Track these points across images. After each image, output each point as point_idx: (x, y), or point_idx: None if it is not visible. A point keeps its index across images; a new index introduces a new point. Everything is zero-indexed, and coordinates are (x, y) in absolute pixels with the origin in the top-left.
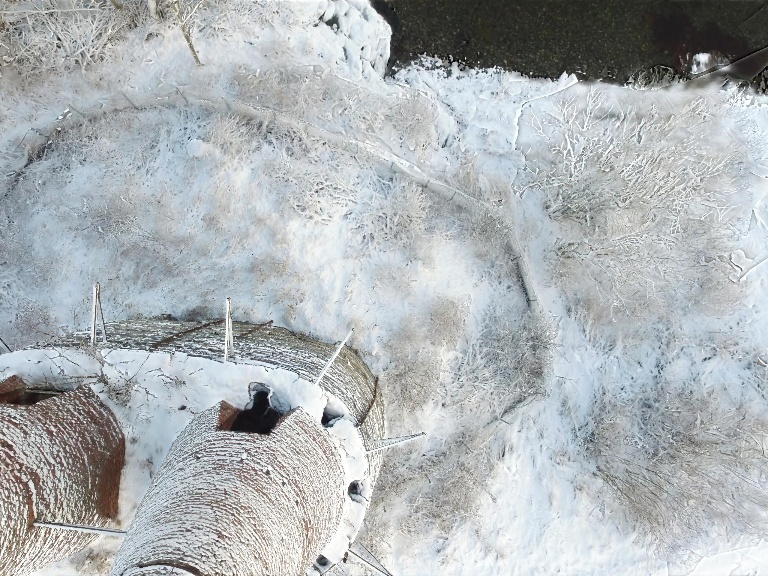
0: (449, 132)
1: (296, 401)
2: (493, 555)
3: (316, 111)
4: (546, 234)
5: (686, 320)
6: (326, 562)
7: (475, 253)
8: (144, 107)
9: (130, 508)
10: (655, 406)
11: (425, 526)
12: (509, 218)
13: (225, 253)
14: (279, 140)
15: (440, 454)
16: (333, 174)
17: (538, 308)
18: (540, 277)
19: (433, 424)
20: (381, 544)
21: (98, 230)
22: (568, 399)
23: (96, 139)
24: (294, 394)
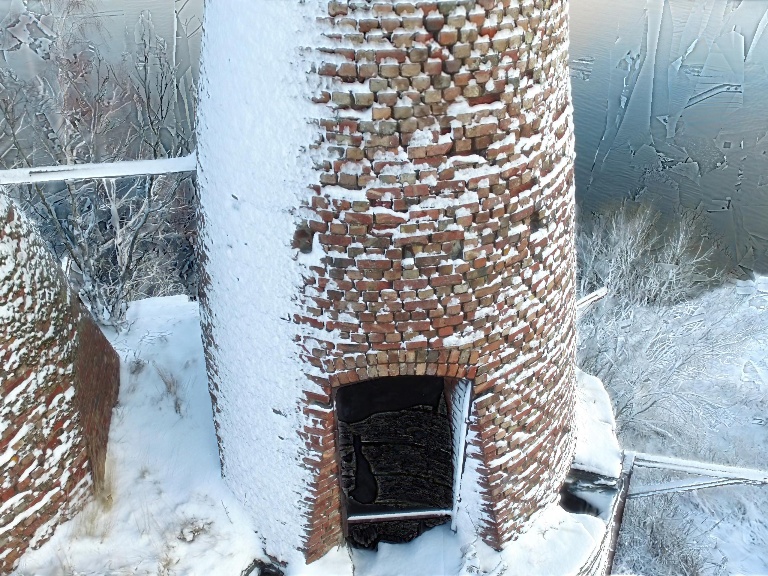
0: None
1: None
2: None
3: None
4: None
5: None
6: (596, 513)
7: None
8: None
9: (132, 479)
10: None
11: None
12: None
13: None
14: None
15: None
16: None
17: None
18: None
19: None
20: None
21: None
22: None
23: None
24: None
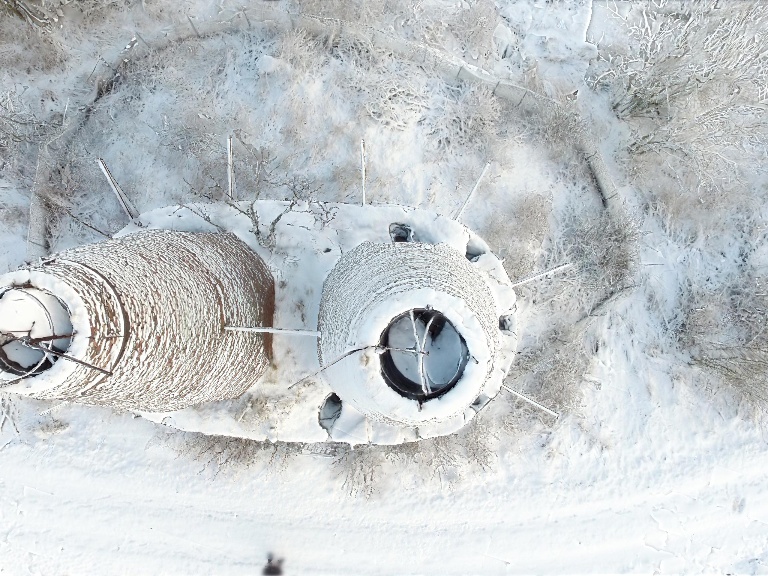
0: (508, 43)
1: (439, 238)
2: (598, 447)
3: (378, 24)
4: (615, 135)
5: (766, 208)
6: (479, 401)
7: (548, 156)
8: (207, 35)
9: (284, 353)
10: (745, 292)
11: (527, 422)
12: (582, 114)
13: (305, 164)
14: (346, 53)
15: (535, 351)
16: (405, 80)
17: (619, 201)
18: (613, 177)
19: (525, 322)
20: (486, 442)
21: (178, 149)
22: (655, 293)
23: (163, 68)
24: (436, 231)
